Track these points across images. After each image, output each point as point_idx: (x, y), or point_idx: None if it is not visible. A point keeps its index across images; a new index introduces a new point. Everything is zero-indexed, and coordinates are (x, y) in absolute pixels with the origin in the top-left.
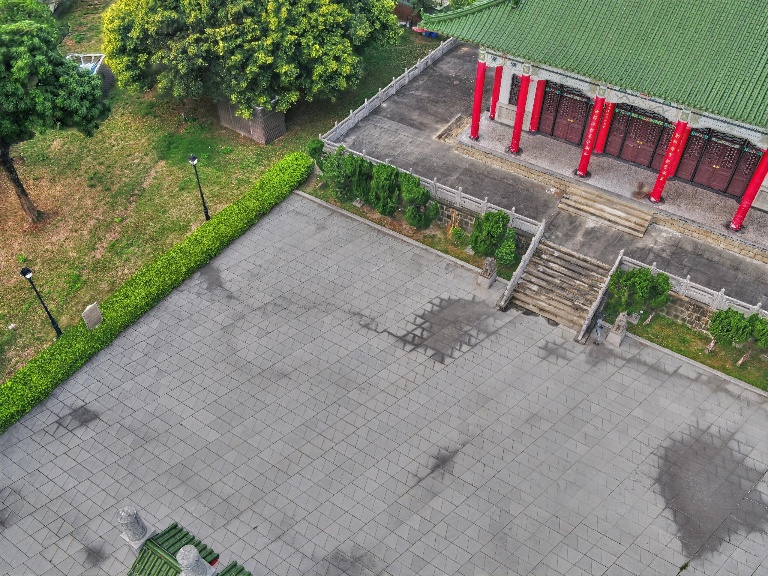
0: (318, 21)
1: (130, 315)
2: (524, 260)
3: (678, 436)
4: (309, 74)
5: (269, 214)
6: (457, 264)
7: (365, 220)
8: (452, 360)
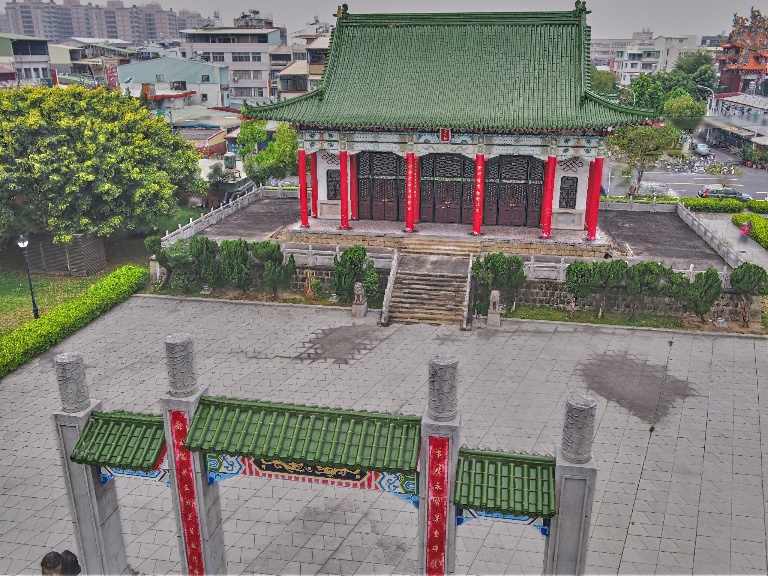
0: (134, 152)
1: None
2: (390, 281)
3: (585, 361)
4: (128, 205)
5: (110, 312)
6: (326, 309)
7: (219, 299)
8: (356, 360)
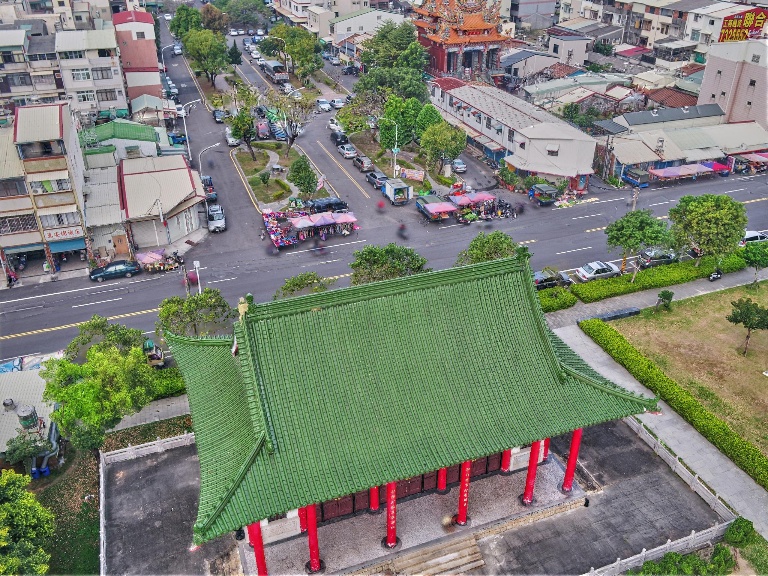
0: None
1: None
2: None
3: None
4: None
5: None
6: None
7: None
8: None
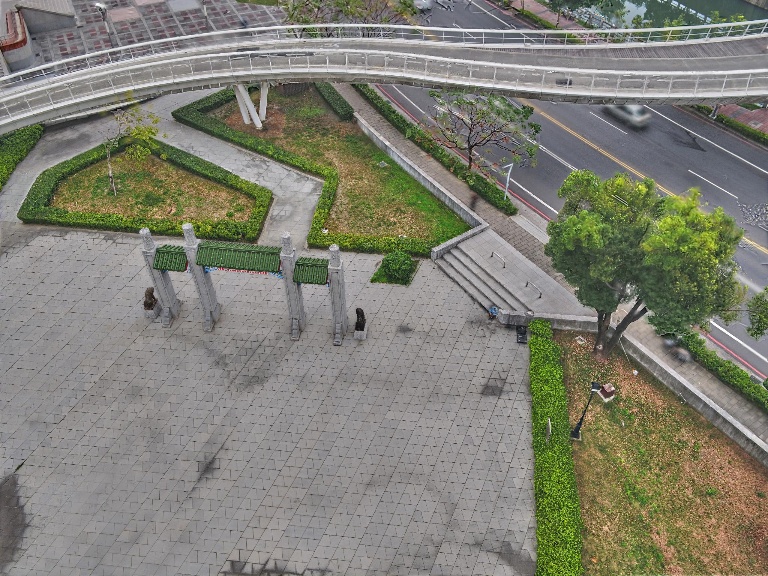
0: None
1: (538, 469)
2: None
3: None
4: None
5: None
6: None
7: None
8: (223, 569)
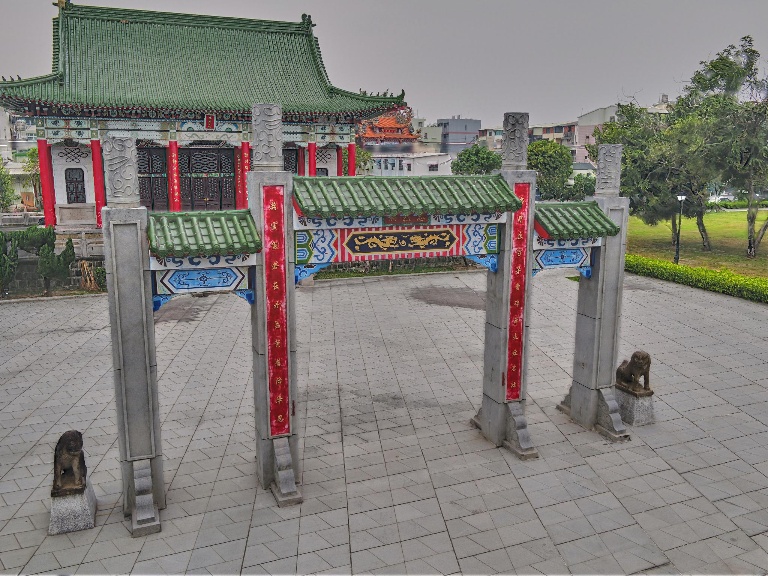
0: None
1: None
2: None
3: None
4: None
5: None
6: None
7: None
8: (201, 317)
